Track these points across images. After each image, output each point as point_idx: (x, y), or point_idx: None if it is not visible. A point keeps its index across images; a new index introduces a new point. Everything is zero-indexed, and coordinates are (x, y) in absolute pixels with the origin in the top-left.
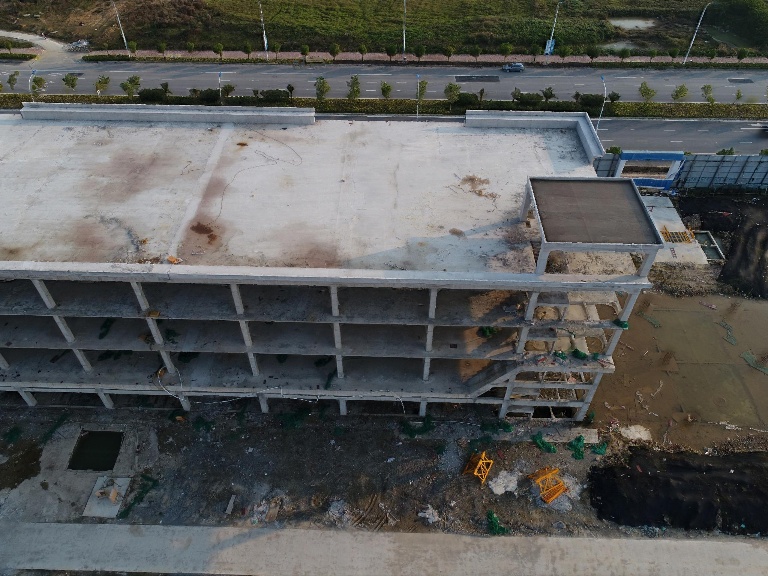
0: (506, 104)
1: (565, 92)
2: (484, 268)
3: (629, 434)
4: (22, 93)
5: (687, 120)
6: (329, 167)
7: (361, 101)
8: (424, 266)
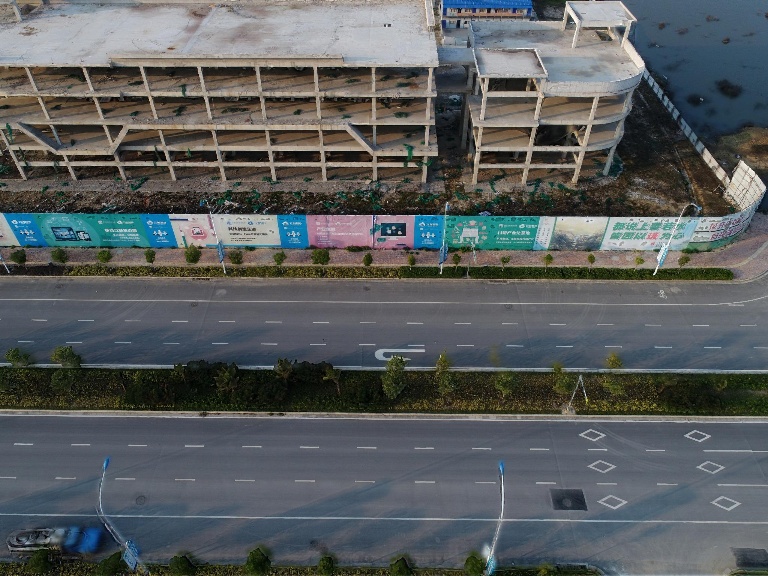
0: None
1: None
2: (63, 6)
3: None
4: (615, 423)
5: None
6: (116, 38)
7: (6, 396)
8: (92, 6)
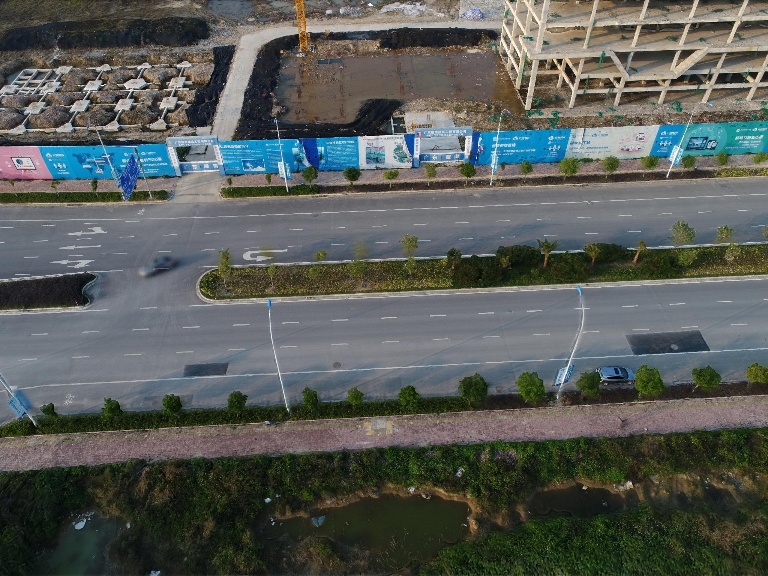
0: (601, 246)
1: (516, 314)
2: None
3: (477, 50)
4: None
5: (351, 261)
6: None
7: None
8: None
